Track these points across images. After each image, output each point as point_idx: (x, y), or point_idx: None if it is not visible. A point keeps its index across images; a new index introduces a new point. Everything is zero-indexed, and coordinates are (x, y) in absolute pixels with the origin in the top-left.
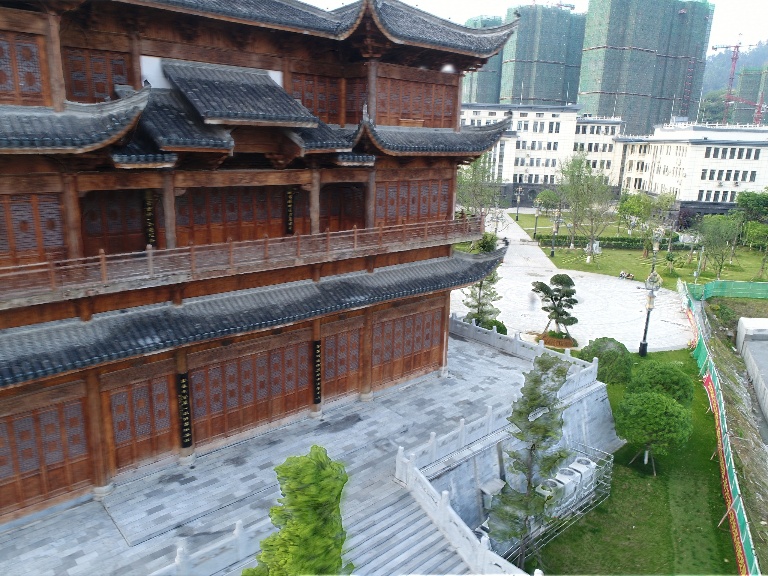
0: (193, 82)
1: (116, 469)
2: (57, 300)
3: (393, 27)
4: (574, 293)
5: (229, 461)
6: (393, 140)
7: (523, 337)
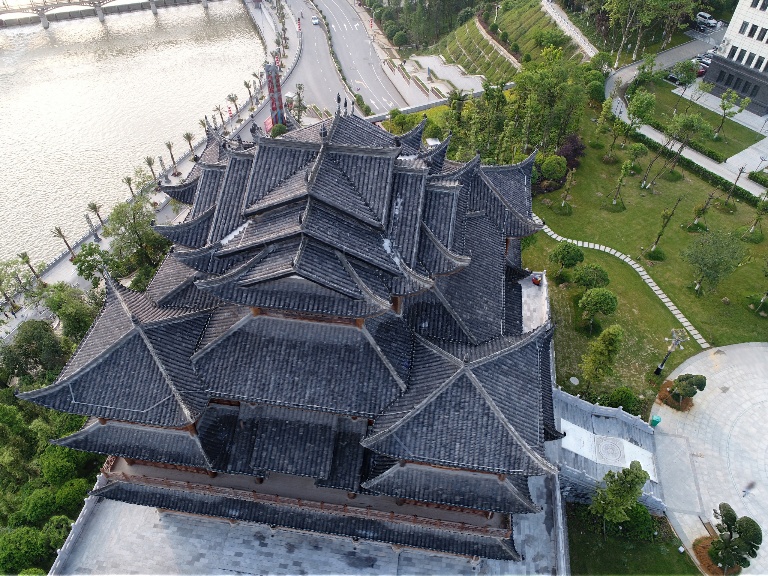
0: (269, 424)
1: (239, 520)
2: (192, 492)
3: (411, 440)
4: (755, 549)
5: (288, 545)
6: (409, 484)
7: (690, 526)
